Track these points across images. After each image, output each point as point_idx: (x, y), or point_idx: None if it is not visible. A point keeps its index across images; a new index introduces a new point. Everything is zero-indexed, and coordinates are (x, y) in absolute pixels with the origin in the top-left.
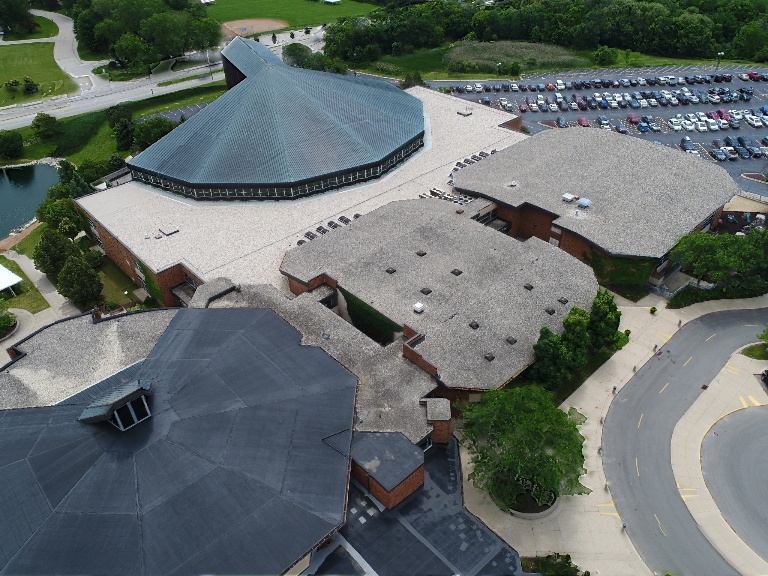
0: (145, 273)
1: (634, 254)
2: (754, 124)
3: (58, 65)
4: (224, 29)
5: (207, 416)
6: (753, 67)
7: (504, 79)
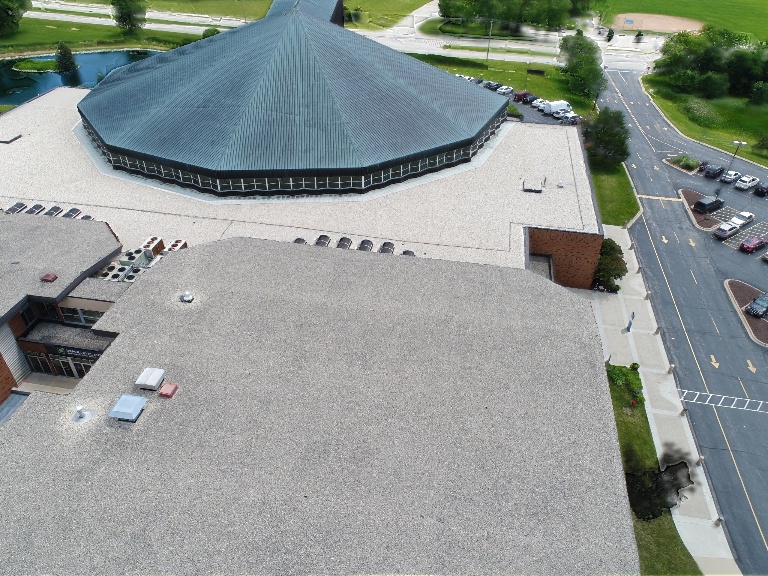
0: None
1: None
2: None
3: (417, 8)
4: (573, 8)
5: None
6: None
7: None
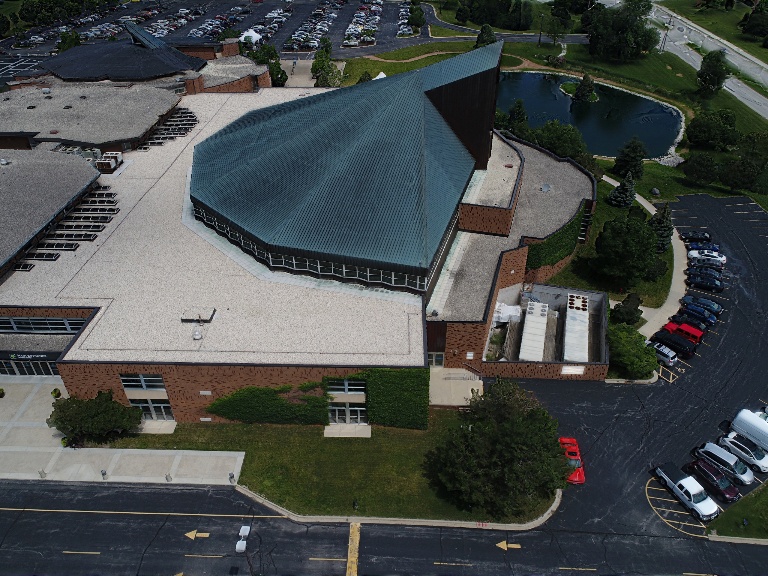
0: None
1: None
2: None
3: None
4: None
5: (113, 51)
6: None
7: None
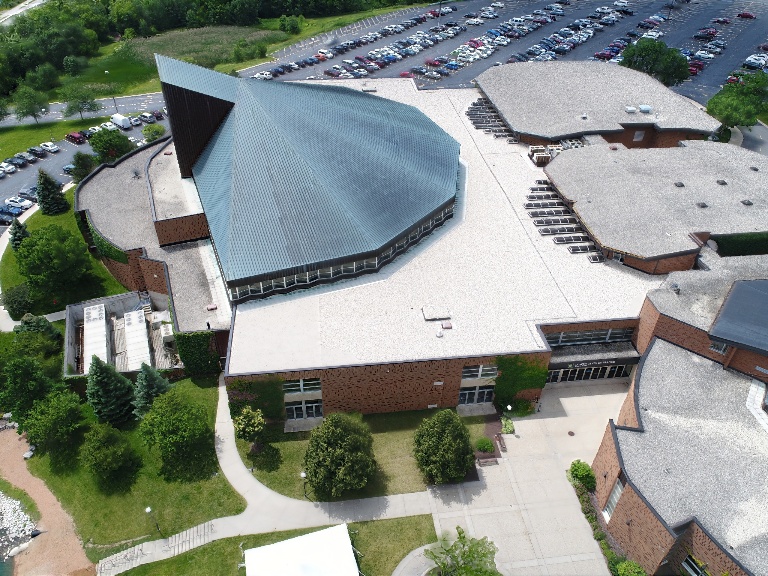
0: (512, 367)
1: (717, 127)
2: (503, 44)
3: None
4: None
5: None
6: (415, 9)
7: (263, 63)
